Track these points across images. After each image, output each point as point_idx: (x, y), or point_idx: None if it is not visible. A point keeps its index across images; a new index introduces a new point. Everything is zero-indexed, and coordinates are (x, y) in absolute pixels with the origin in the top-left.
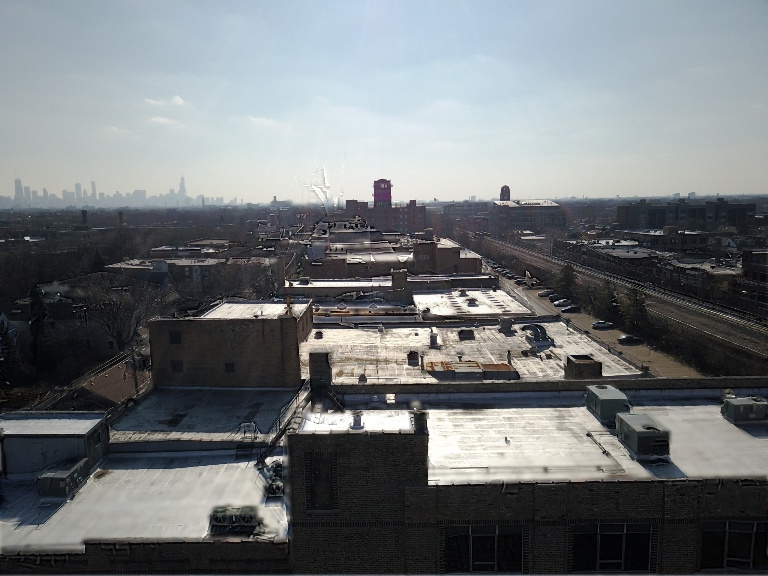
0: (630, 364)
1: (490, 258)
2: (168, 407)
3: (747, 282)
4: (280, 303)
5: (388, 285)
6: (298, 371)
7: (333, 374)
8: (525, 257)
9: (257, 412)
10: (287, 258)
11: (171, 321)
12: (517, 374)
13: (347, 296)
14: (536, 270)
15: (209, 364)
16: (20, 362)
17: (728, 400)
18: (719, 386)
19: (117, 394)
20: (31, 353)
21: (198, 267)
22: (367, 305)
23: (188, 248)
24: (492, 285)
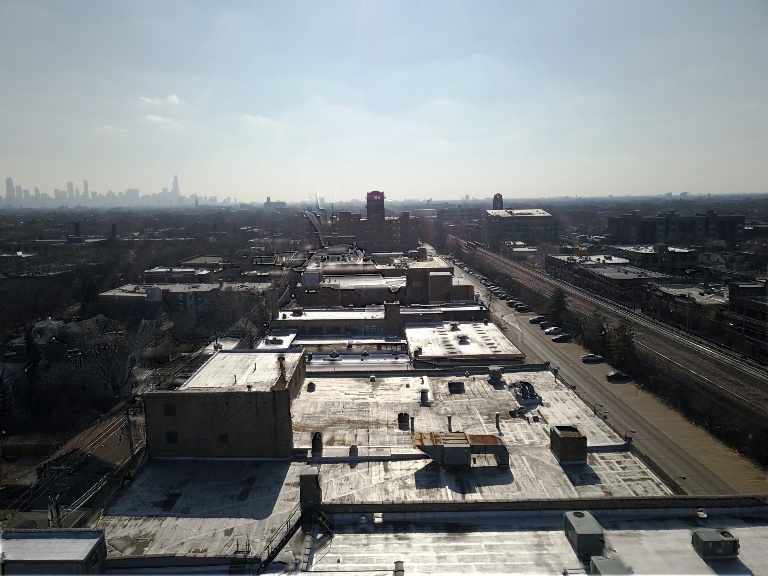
0: (614, 431)
1: (482, 274)
2: (163, 484)
3: (733, 315)
4: (273, 352)
5: (380, 318)
6: (290, 441)
7: (322, 494)
8: (517, 274)
9: (250, 490)
10: (280, 290)
11: (165, 394)
12: (503, 448)
13: (339, 344)
14: (527, 292)
15: (203, 435)
16: (15, 410)
17: (697, 534)
18: (691, 505)
19: (112, 460)
20: (26, 397)
21: (191, 294)
22: (359, 353)
23: (181, 270)
24: (483, 317)
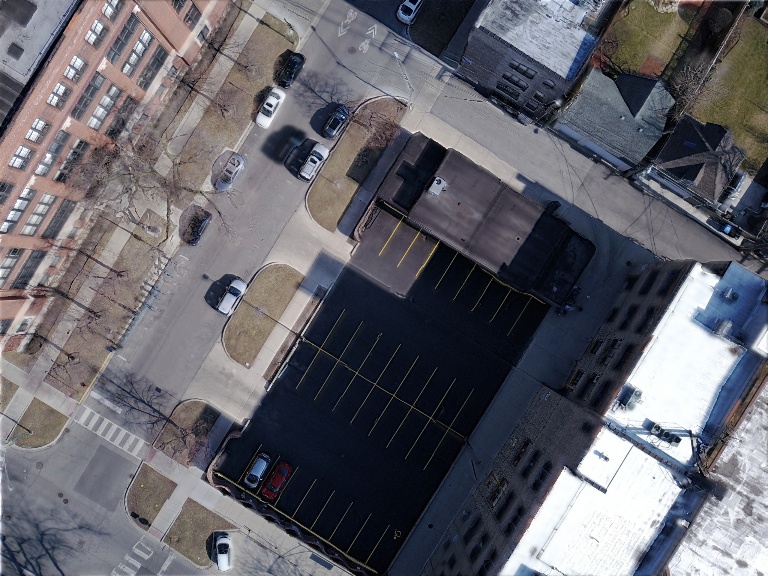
0: None
1: None
2: None
3: None
4: None
5: None
6: None
7: None
8: None
9: None
10: None
11: None
12: None
13: None
14: None
15: None
16: None
17: None
18: None
19: None
20: None
21: None
22: None
23: None
24: None
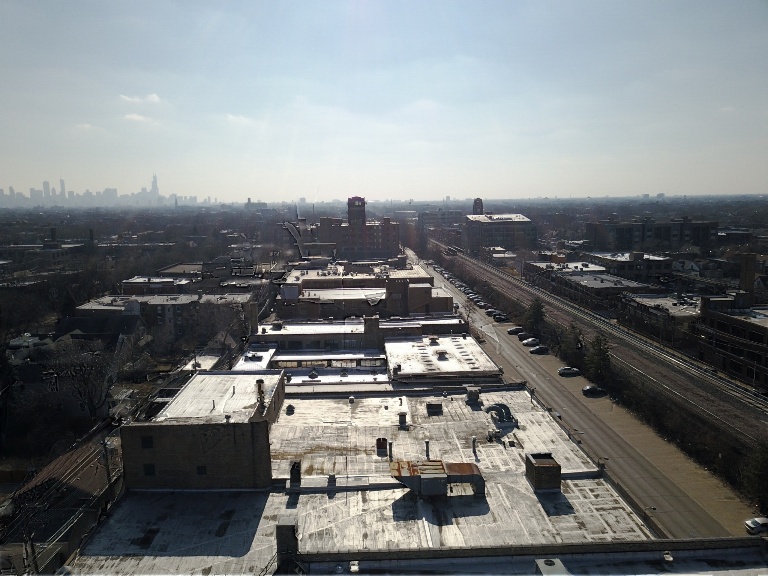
0: (588, 457)
1: (462, 281)
2: (140, 519)
3: (705, 328)
4: (252, 374)
5: (360, 332)
6: (269, 472)
7: (299, 544)
8: (496, 281)
9: (228, 525)
10: (260, 305)
11: (143, 426)
12: (480, 477)
13: (318, 365)
14: (506, 302)
15: (181, 467)
16: None
17: None
18: (658, 549)
19: (89, 491)
20: (0, 419)
21: (171, 306)
22: (338, 374)
23: (160, 280)
24: (462, 331)
